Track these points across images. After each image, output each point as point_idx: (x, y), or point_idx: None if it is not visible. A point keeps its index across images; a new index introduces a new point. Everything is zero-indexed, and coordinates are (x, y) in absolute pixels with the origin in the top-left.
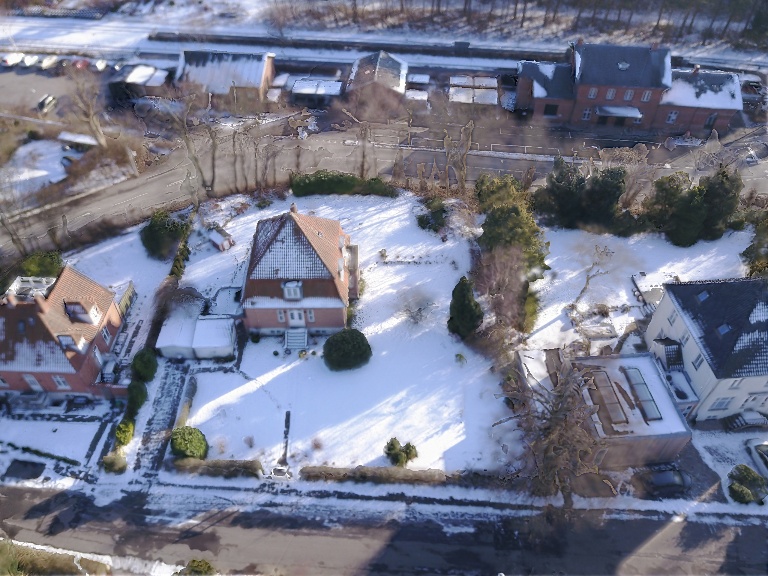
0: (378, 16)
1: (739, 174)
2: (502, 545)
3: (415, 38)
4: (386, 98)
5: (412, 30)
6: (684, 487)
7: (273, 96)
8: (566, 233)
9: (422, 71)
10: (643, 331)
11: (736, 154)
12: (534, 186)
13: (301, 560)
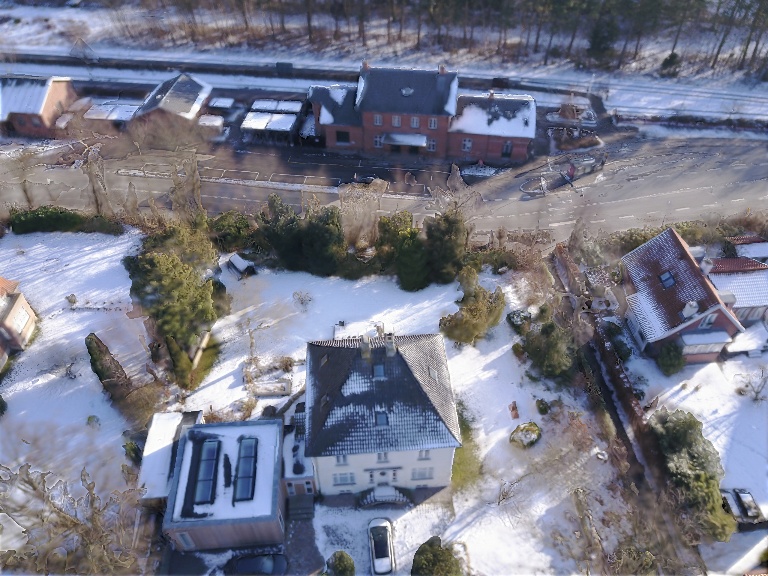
0: (220, 34)
1: (460, 215)
2: None
3: (248, 58)
4: (175, 124)
5: (249, 49)
6: (274, 575)
7: (62, 122)
8: (287, 276)
9: (236, 94)
10: None
11: (471, 192)
12: None
13: None
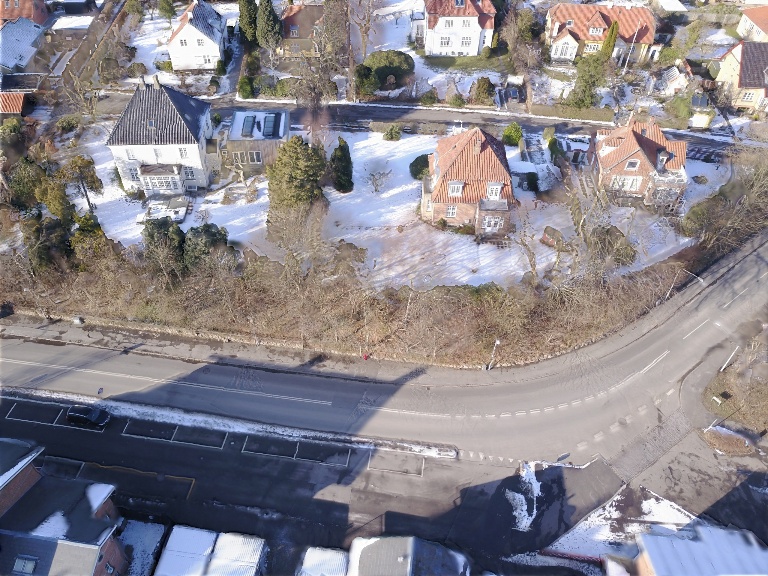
0: None
1: None
2: (345, 116)
3: None
4: None
5: None
6: None
7: None
8: None
9: None
10: (205, 190)
11: None
12: (200, 362)
13: (441, 114)
